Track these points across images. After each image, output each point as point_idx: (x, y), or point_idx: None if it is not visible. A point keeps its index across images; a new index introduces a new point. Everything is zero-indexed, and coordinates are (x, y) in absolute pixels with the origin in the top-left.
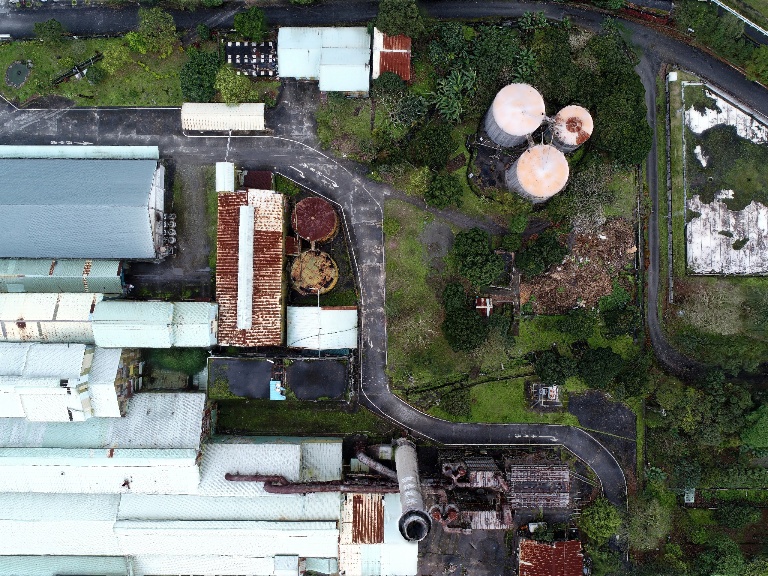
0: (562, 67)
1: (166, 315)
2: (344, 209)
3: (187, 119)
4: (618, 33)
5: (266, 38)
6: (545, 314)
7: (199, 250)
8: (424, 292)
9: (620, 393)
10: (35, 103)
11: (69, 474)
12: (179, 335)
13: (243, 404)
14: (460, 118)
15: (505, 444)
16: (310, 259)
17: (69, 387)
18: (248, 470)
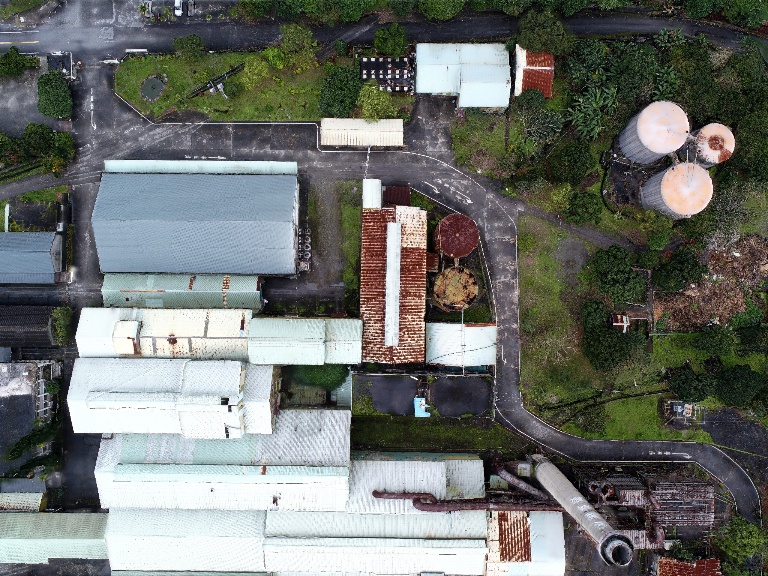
0: (704, 85)
1: (321, 332)
2: (478, 225)
3: (326, 135)
4: (759, 51)
5: (400, 53)
6: (679, 331)
7: (333, 265)
8: (558, 308)
9: (761, 411)
10: (169, 117)
11: (218, 491)
12: (331, 352)
13: (376, 420)
14: (597, 135)
15: (639, 461)
16: (454, 276)
17: (230, 405)
18: (395, 487)
